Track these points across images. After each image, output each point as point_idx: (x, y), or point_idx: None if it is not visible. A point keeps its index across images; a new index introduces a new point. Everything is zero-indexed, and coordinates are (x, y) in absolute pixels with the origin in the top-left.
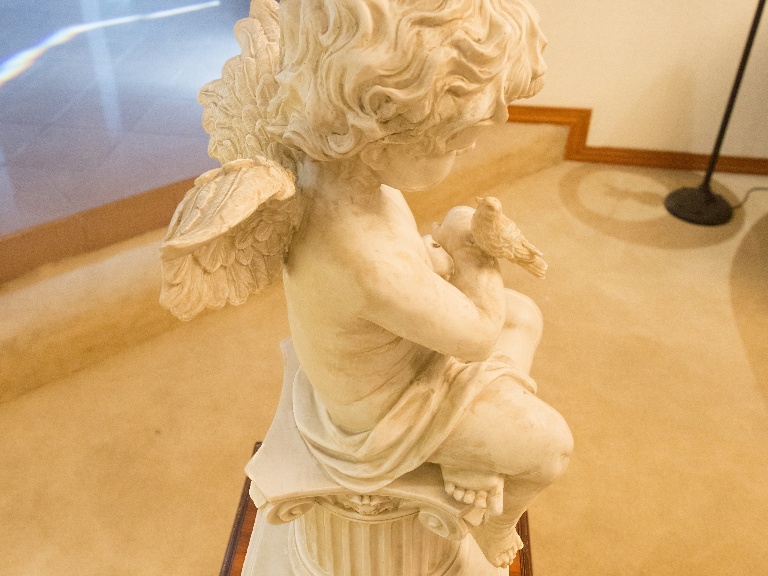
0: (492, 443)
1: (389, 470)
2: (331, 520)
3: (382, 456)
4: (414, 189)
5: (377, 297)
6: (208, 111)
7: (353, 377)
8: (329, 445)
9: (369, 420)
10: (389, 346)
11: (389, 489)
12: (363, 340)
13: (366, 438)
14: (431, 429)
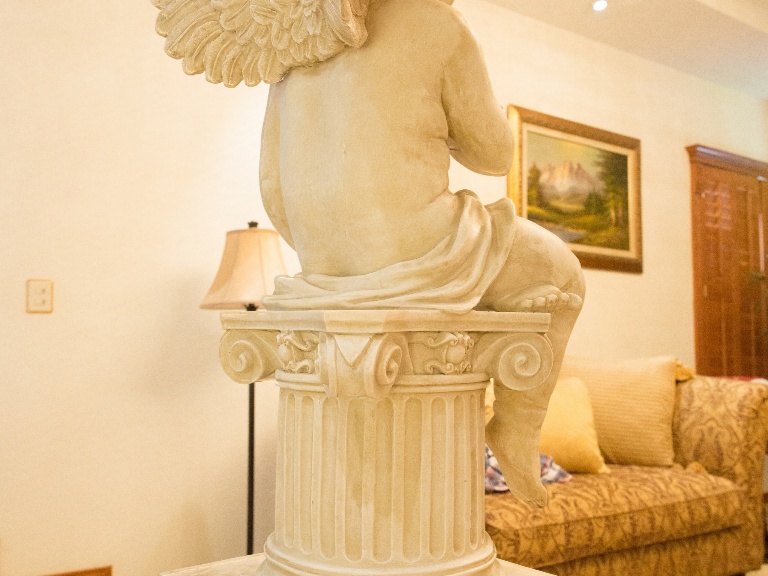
0: (545, 240)
1: (477, 280)
2: (405, 418)
3: (465, 268)
4: (441, 0)
5: (469, 36)
6: (177, 0)
7: (429, 166)
8: (397, 288)
9: (445, 224)
10: None
11: (479, 311)
12: (439, 114)
13: (451, 240)
14: (498, 229)
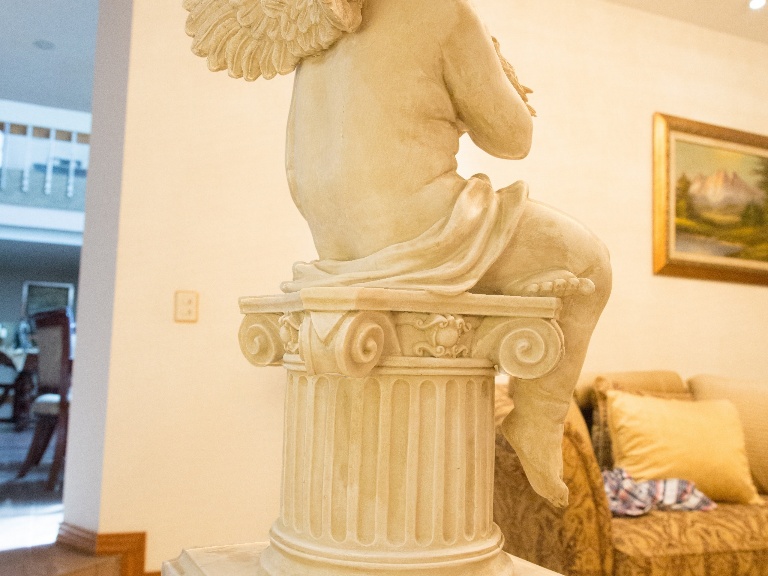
0: (560, 223)
1: (474, 262)
2: (392, 400)
3: (462, 250)
4: None
5: (468, 14)
6: (203, 2)
7: (426, 147)
8: (389, 270)
9: (443, 206)
10: (450, 126)
11: (474, 294)
12: (439, 94)
13: (446, 221)
14: (504, 211)
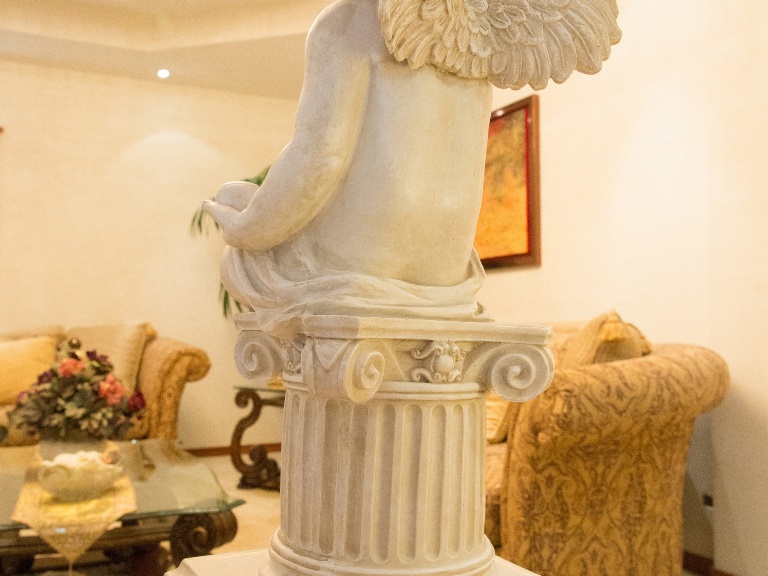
0: None
1: None
2: None
3: None
4: None
5: None
6: None
7: None
8: None
9: None
10: None
11: None
12: None
13: None
14: None
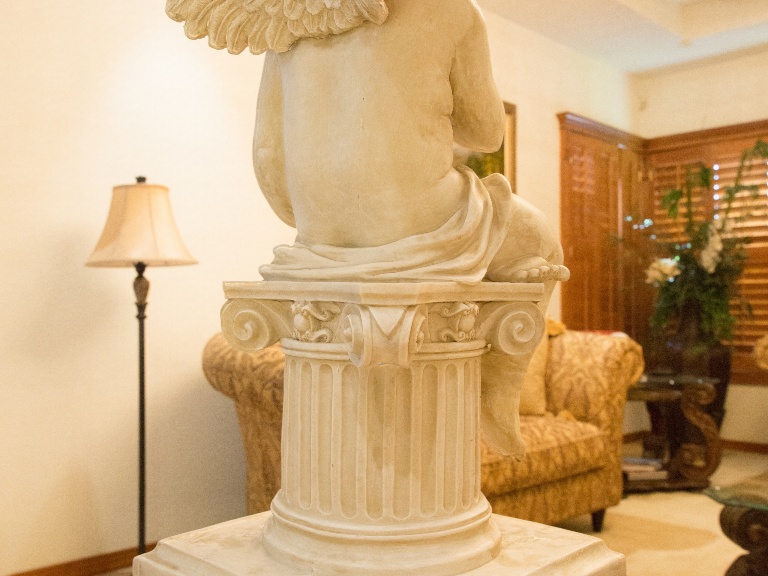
0: (534, 215)
1: (484, 253)
2: (422, 384)
3: (473, 241)
4: None
5: (479, 18)
6: None
7: (441, 143)
8: (413, 260)
9: (455, 199)
10: None
11: (485, 282)
12: None
13: (462, 214)
14: (497, 204)
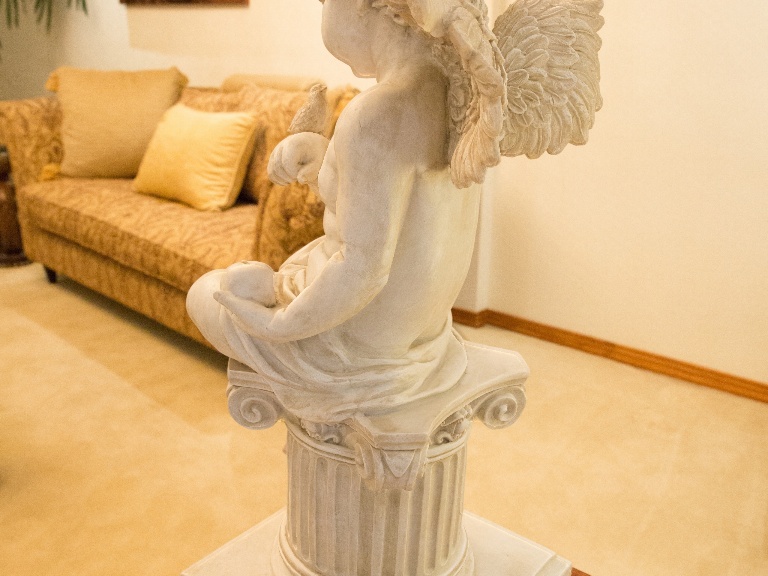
0: None
1: None
2: None
3: None
4: None
5: None
6: None
7: None
8: None
9: None
10: None
11: None
12: None
13: None
14: None
